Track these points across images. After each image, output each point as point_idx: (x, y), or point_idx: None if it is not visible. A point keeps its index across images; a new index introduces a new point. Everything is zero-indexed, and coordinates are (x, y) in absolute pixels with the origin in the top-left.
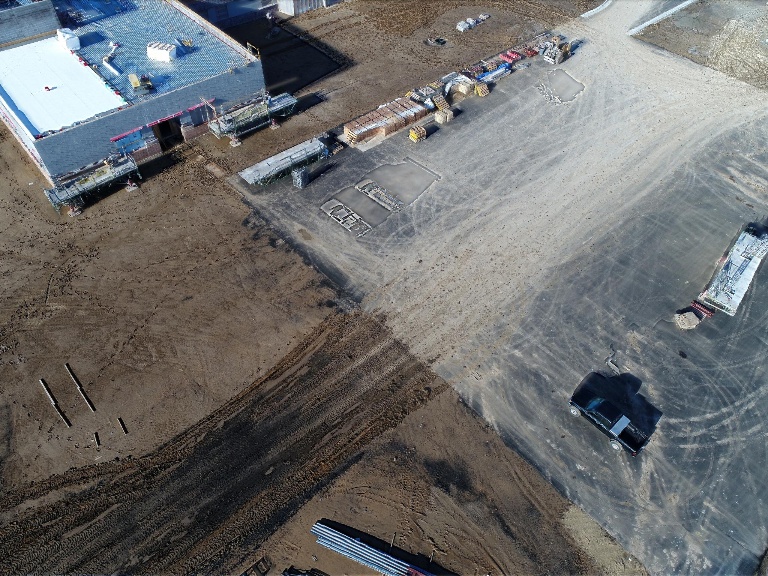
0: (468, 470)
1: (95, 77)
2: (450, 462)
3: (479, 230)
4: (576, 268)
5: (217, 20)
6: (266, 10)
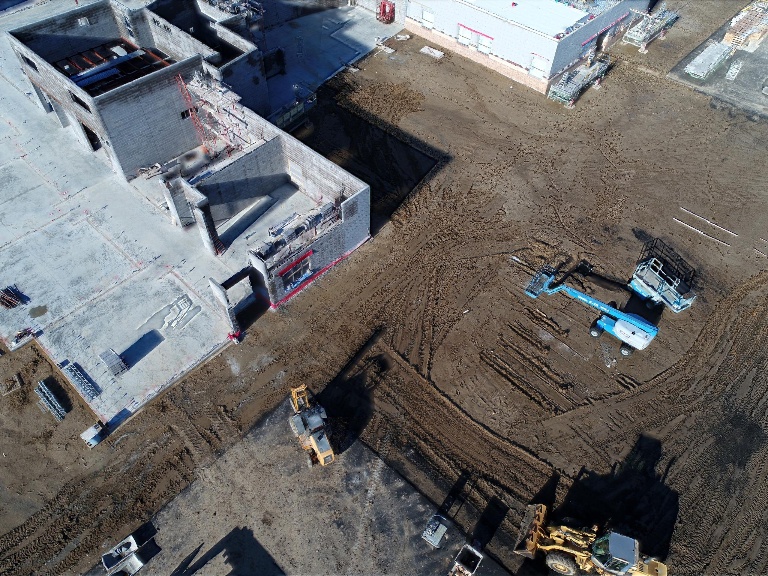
0: None
1: None
2: None
3: None
4: None
5: None
6: None
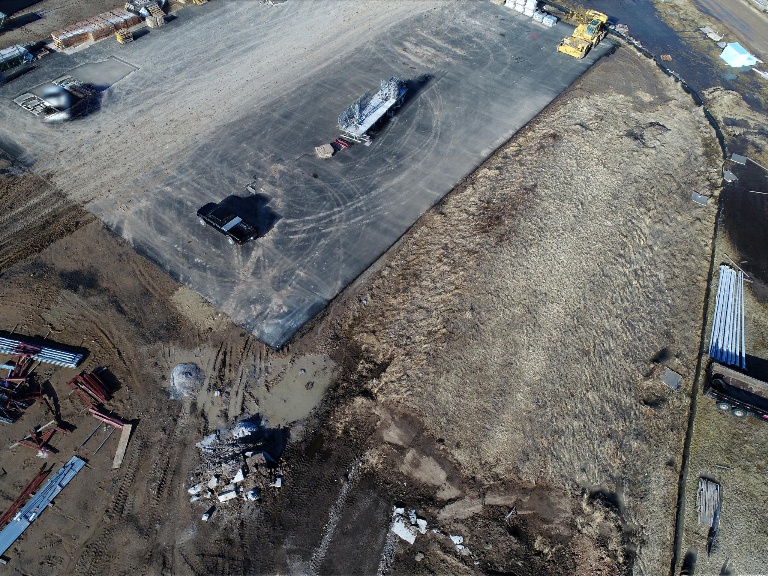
0: (98, 274)
1: None
2: (83, 271)
3: (162, 104)
4: (242, 124)
5: None
6: None
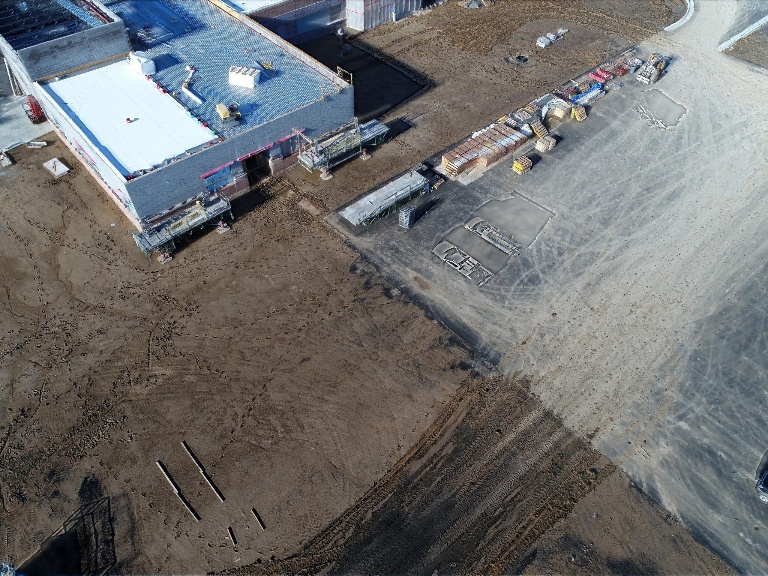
0: (658, 572)
1: (177, 106)
2: (635, 561)
3: (610, 276)
4: (725, 321)
5: (286, 37)
6: (334, 25)
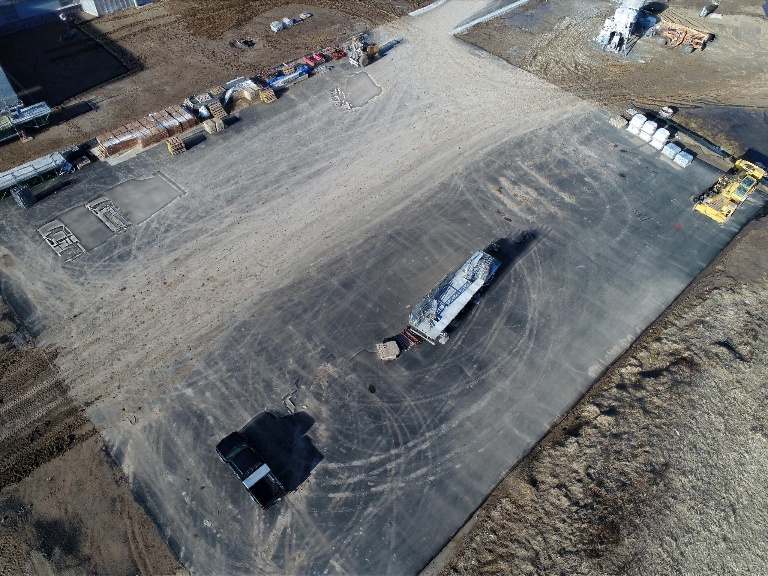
0: (81, 530)
1: None
2: (65, 521)
3: (203, 252)
4: (292, 293)
5: (5, 22)
6: (67, 10)
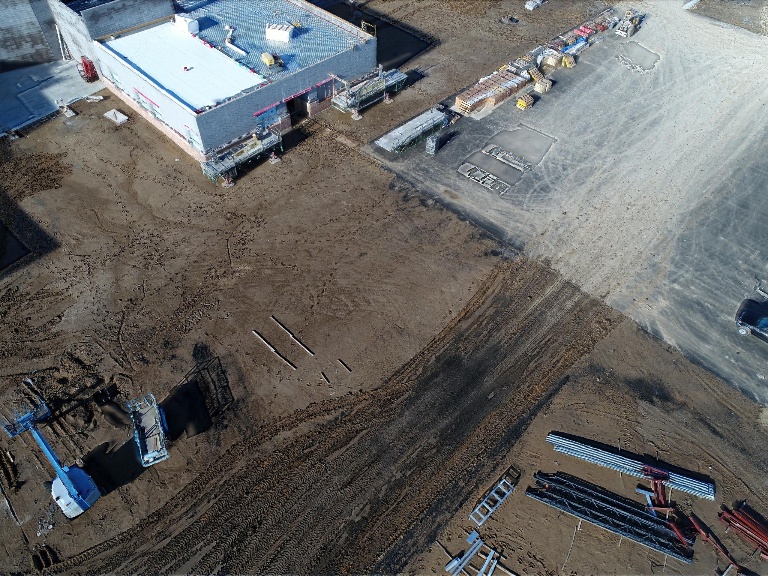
0: (665, 385)
1: (225, 57)
2: (647, 379)
3: (608, 184)
4: (704, 213)
5: None
6: None
